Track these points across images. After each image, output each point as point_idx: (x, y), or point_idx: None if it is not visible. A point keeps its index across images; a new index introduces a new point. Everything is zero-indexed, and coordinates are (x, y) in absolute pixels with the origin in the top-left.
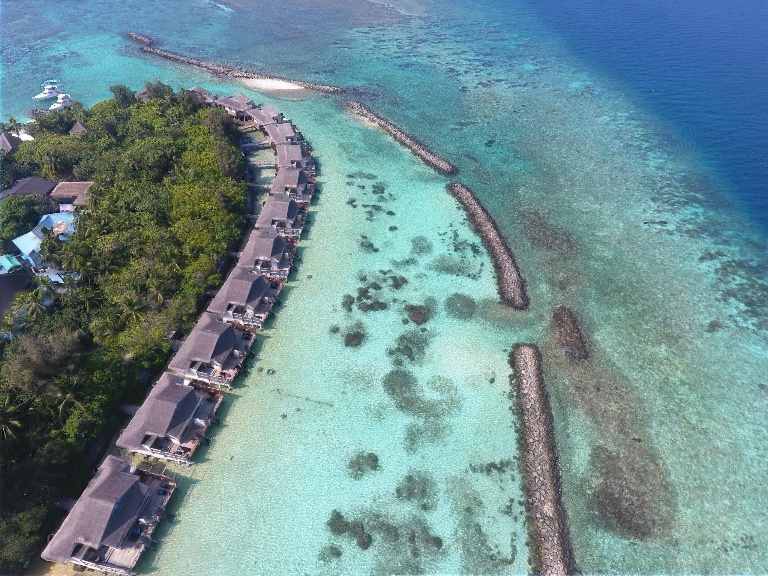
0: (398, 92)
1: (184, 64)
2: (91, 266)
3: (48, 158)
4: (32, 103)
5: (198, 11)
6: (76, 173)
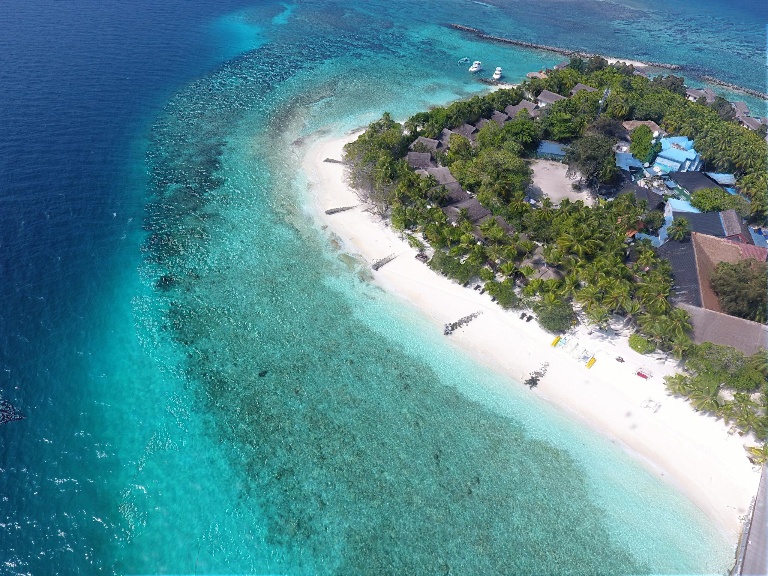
0: (722, 69)
1: (530, 48)
2: (766, 163)
3: (623, 103)
4: (467, 75)
5: (469, 7)
6: (638, 115)
